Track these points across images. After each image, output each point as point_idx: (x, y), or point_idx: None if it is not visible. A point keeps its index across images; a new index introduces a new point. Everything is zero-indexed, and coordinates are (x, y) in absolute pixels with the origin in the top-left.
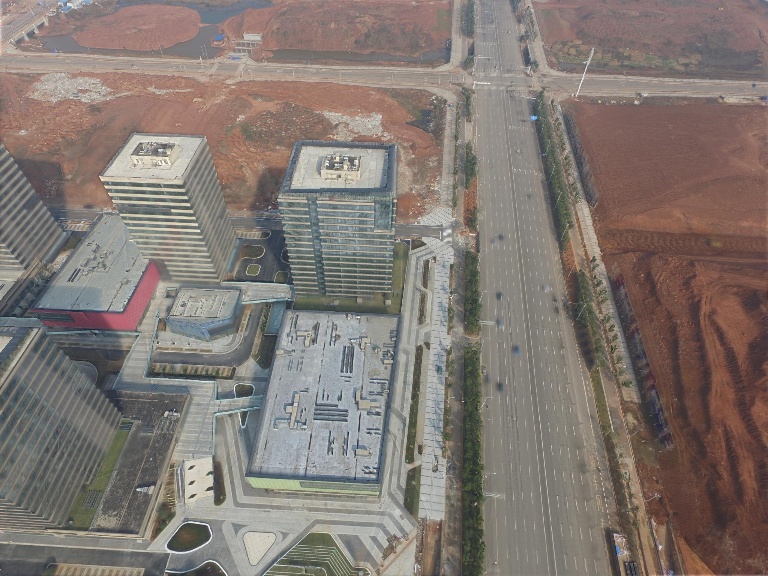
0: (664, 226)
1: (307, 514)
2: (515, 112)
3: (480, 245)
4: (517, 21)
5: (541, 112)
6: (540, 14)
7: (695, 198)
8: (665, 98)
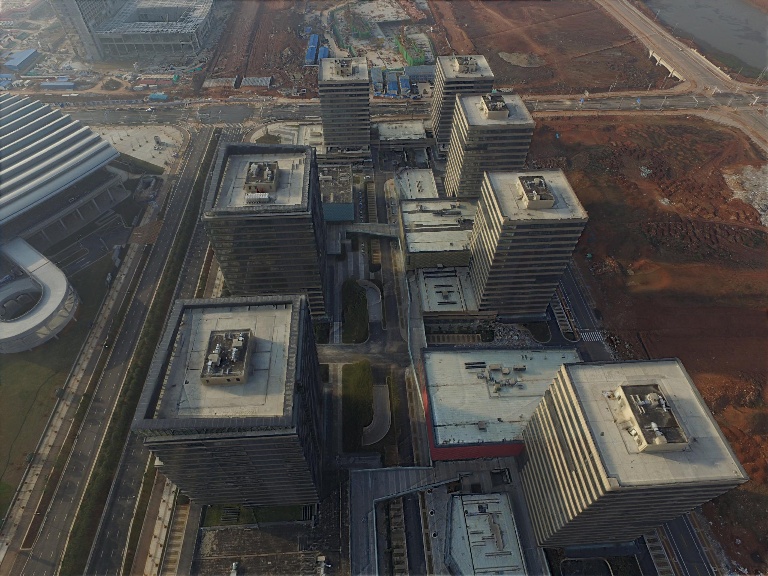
0: None
1: None
2: None
3: None
4: None
5: None
6: None
7: None
8: None
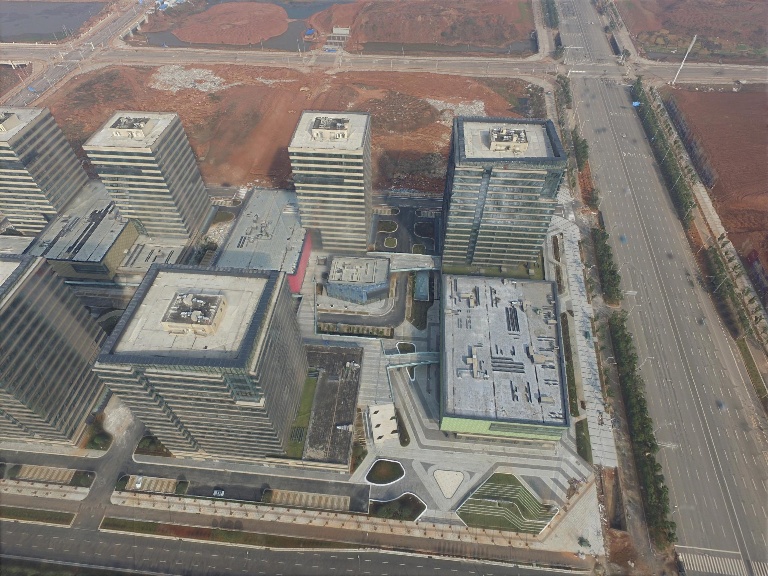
0: None
1: (488, 457)
2: (614, 99)
3: (604, 223)
4: (598, 12)
5: (642, 99)
6: (623, 5)
7: None
8: (765, 85)
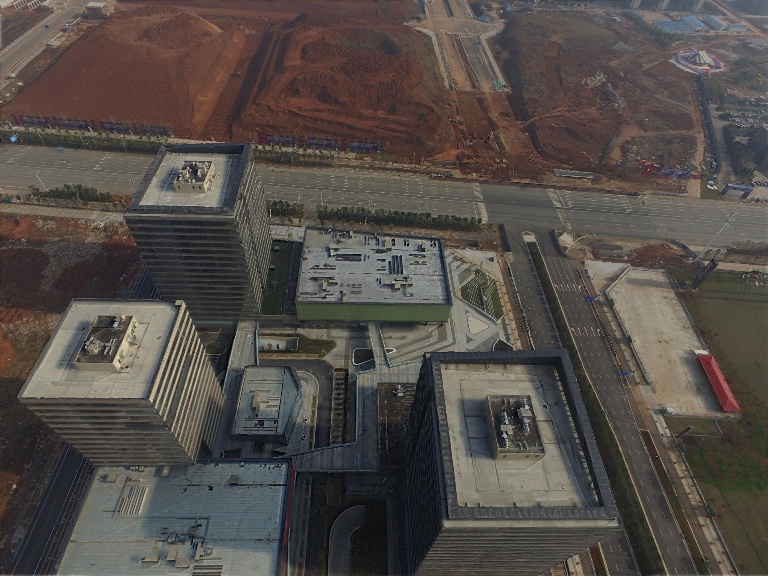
0: (208, 110)
1: None
2: None
3: None
4: None
5: (5, 133)
6: None
7: (191, 85)
8: (28, 68)
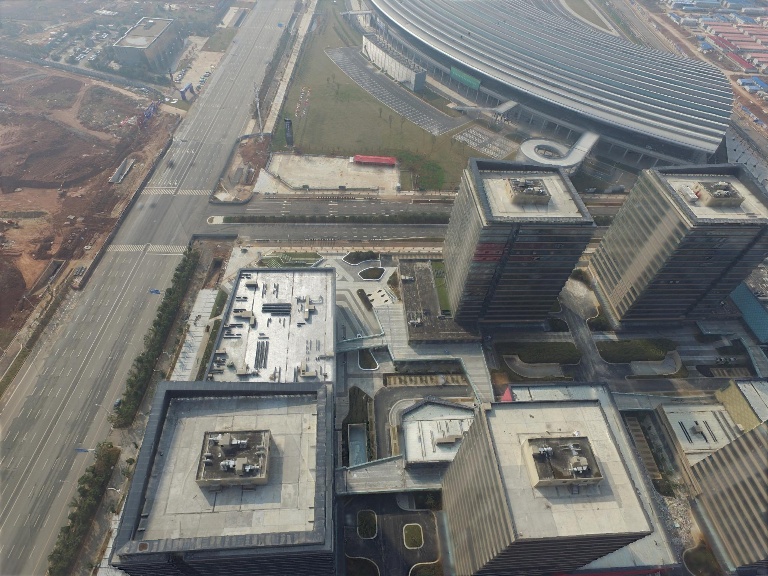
0: None
1: None
2: None
3: None
4: None
5: None
6: None
7: None
8: None
